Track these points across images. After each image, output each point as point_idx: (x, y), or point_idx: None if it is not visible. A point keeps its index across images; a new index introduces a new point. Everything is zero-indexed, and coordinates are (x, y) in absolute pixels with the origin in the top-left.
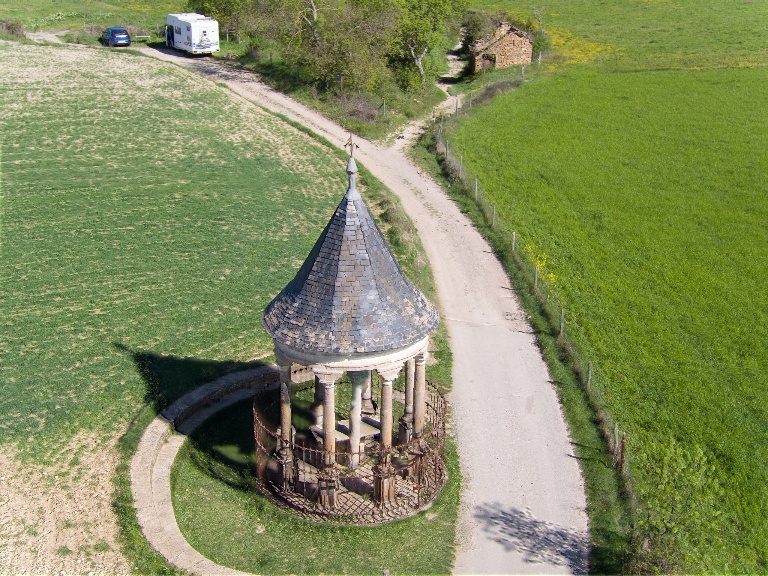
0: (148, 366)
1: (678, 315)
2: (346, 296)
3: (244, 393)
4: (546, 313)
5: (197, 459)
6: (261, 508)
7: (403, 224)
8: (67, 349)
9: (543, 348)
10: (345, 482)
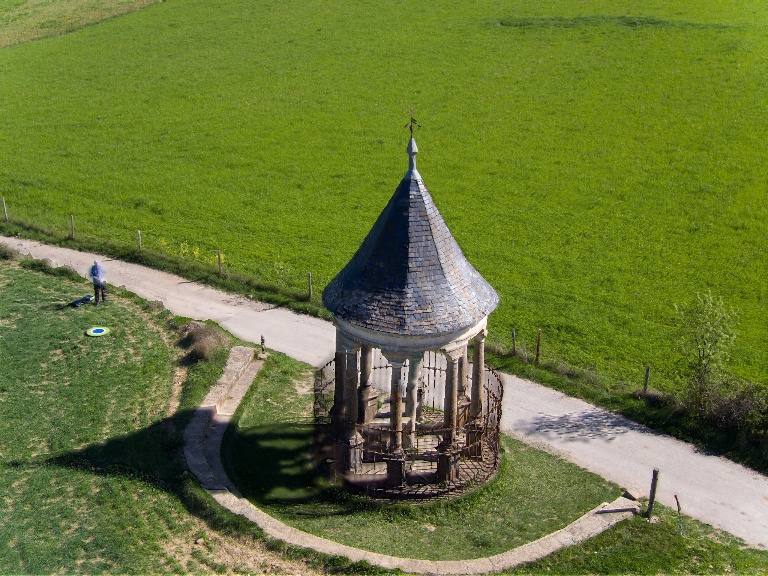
0: (89, 464)
1: (347, 254)
2: (451, 270)
3: (212, 443)
4: (264, 287)
5: (274, 513)
6: (407, 512)
7: (23, 256)
8: None
9: (314, 313)
10: (426, 459)
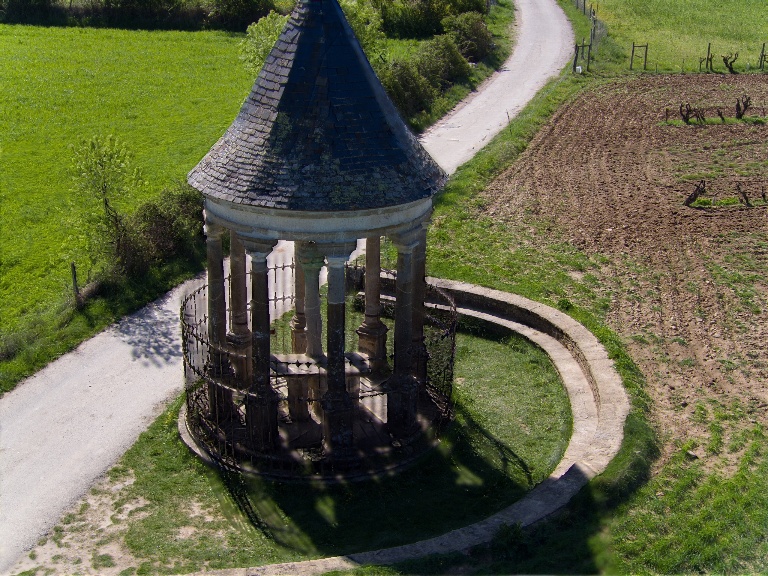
0: None
1: None
2: None
3: None
4: None
5: None
6: None
7: None
8: None
9: None
10: None
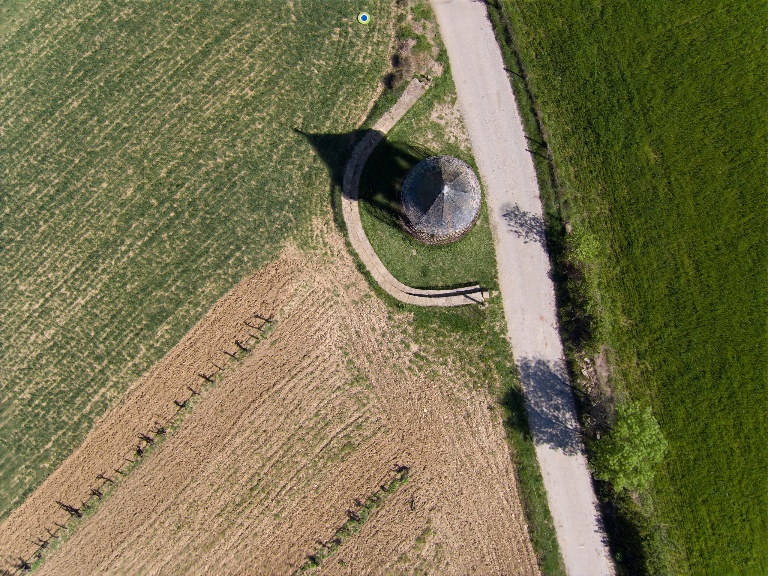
0: (311, 149)
1: None
2: None
3: (366, 154)
4: None
5: (367, 211)
6: (411, 242)
7: None
8: (260, 143)
9: (494, 27)
10: None
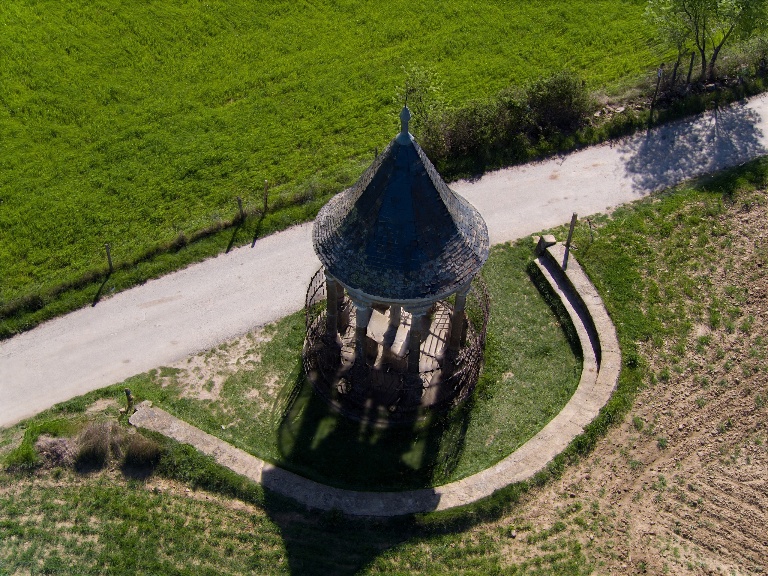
0: None
1: None
2: None
3: None
4: None
5: None
6: None
7: None
8: None
9: (5, 334)
10: None
